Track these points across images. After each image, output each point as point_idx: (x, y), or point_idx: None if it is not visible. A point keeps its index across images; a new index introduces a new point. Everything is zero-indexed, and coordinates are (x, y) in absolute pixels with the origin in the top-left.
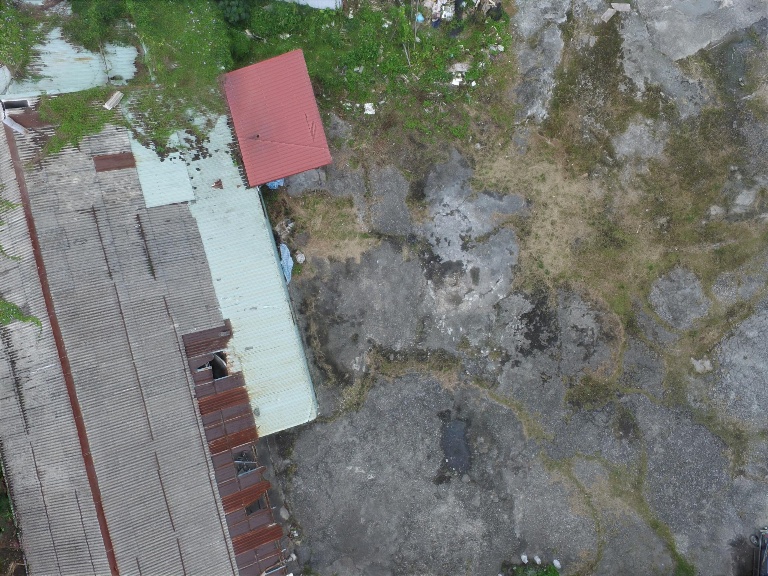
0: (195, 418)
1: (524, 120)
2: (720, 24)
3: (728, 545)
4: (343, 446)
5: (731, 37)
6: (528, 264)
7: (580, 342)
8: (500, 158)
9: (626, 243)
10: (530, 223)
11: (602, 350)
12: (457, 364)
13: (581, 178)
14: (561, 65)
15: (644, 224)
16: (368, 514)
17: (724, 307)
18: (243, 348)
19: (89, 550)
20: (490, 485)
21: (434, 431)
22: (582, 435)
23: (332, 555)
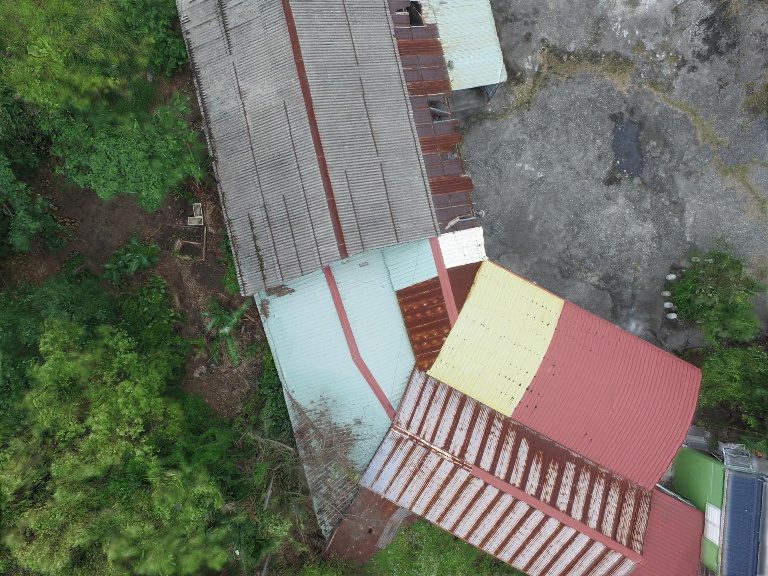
0: (395, 56)
1: None
2: None
3: None
4: (513, 143)
5: None
6: None
7: (758, 50)
8: None
9: None
10: None
11: None
12: (632, 67)
13: None
14: None
15: None
16: (537, 211)
17: None
18: (438, 2)
19: (297, 161)
20: (661, 188)
21: (606, 132)
22: (757, 142)
23: (499, 250)
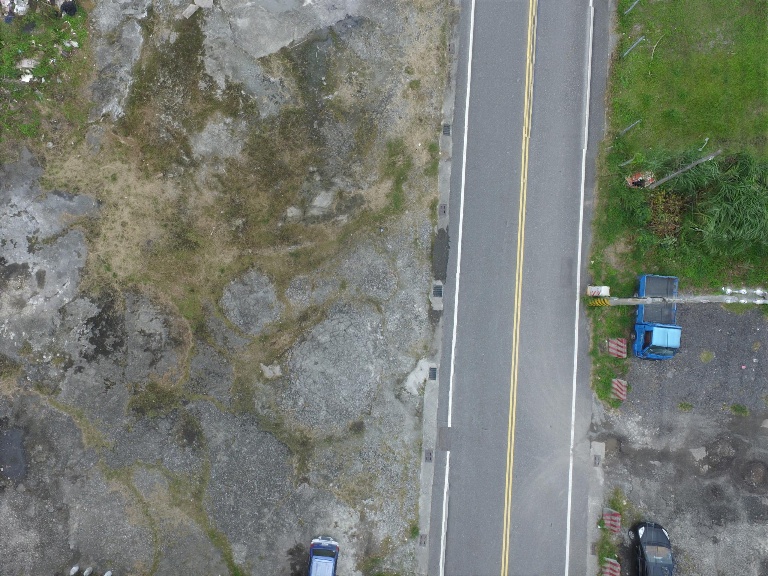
0: None
1: (99, 118)
2: (303, 22)
3: (288, 555)
4: None
5: (315, 35)
6: (96, 267)
7: (147, 347)
8: (72, 157)
9: (199, 245)
10: (100, 225)
11: (170, 355)
12: (17, 370)
13: (155, 178)
14: (139, 62)
15: (219, 226)
16: None
17: (297, 311)
18: None
19: None
20: (45, 495)
21: None
22: (144, 443)
23: None
